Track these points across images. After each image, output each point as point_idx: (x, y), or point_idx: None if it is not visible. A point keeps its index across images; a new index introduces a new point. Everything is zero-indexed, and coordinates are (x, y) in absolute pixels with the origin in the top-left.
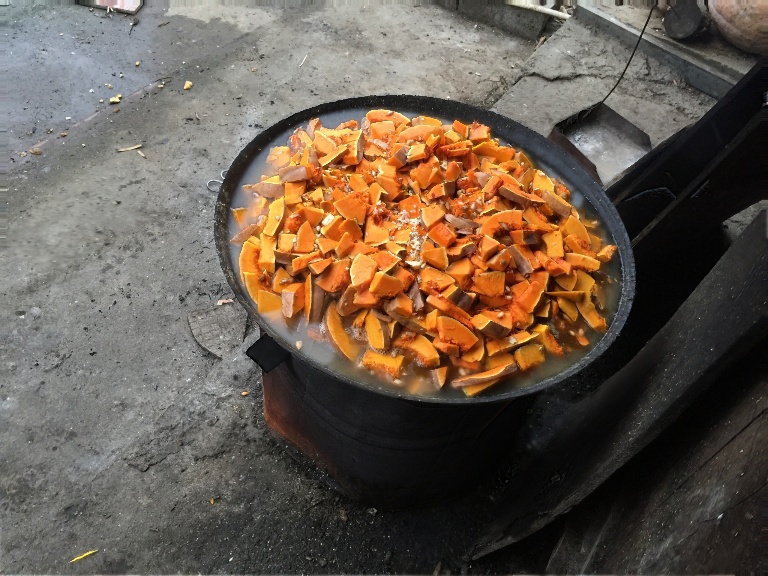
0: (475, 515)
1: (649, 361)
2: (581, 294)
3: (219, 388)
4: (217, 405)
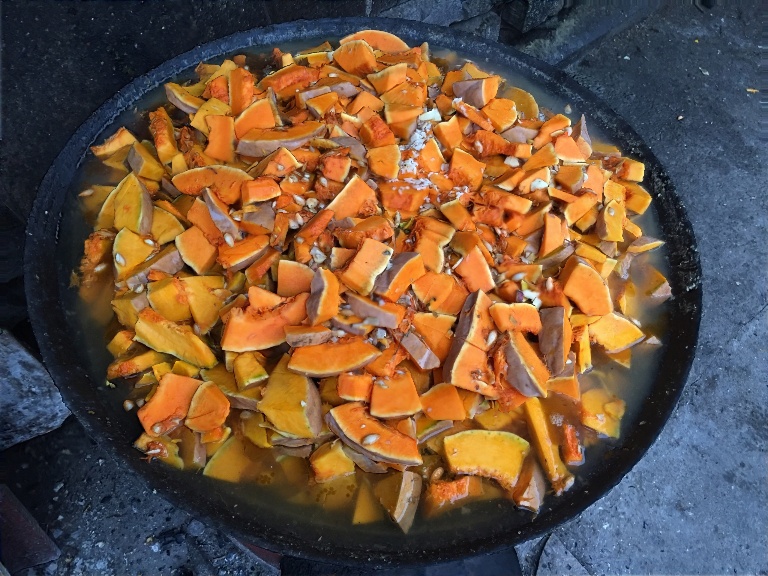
0: None
1: None
2: None
3: None
4: None
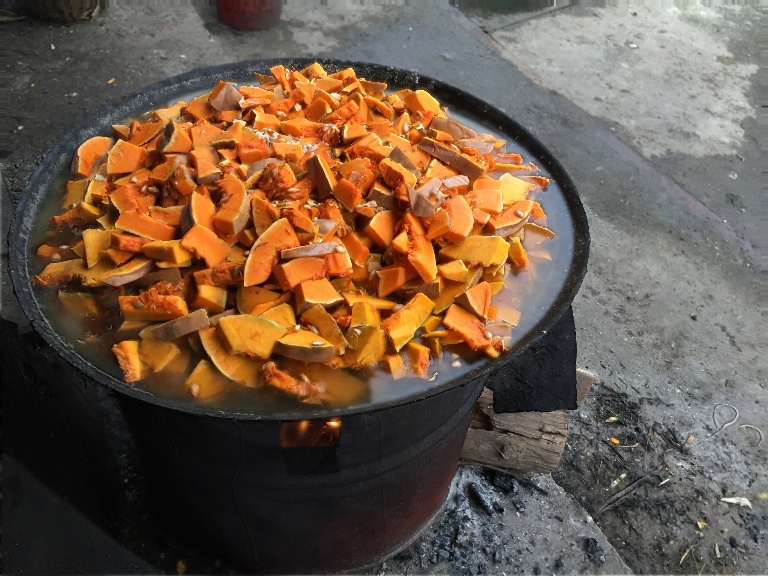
0: (122, 429)
1: None
2: (86, 255)
3: None
4: None
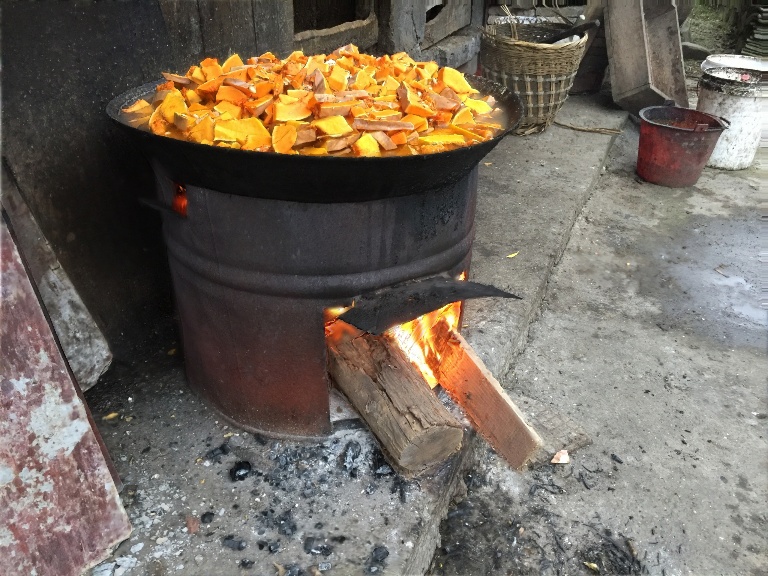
0: None
1: (97, 171)
2: None
3: (491, 327)
4: (484, 316)
